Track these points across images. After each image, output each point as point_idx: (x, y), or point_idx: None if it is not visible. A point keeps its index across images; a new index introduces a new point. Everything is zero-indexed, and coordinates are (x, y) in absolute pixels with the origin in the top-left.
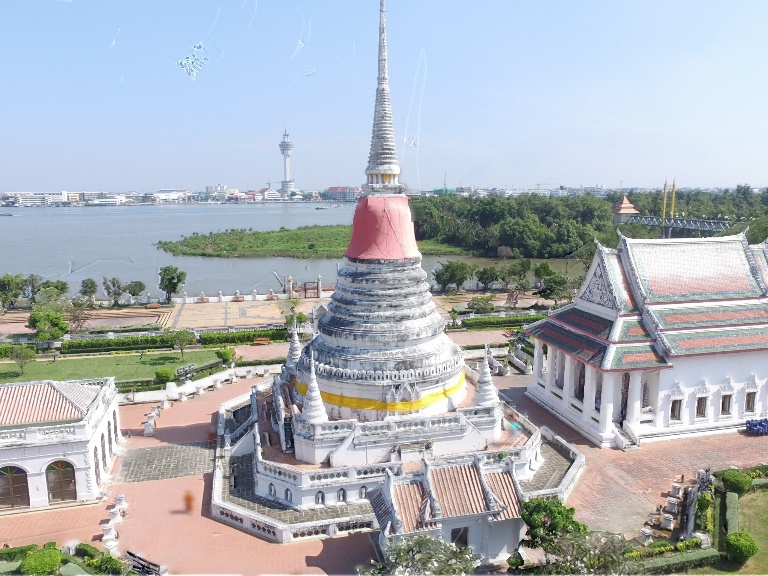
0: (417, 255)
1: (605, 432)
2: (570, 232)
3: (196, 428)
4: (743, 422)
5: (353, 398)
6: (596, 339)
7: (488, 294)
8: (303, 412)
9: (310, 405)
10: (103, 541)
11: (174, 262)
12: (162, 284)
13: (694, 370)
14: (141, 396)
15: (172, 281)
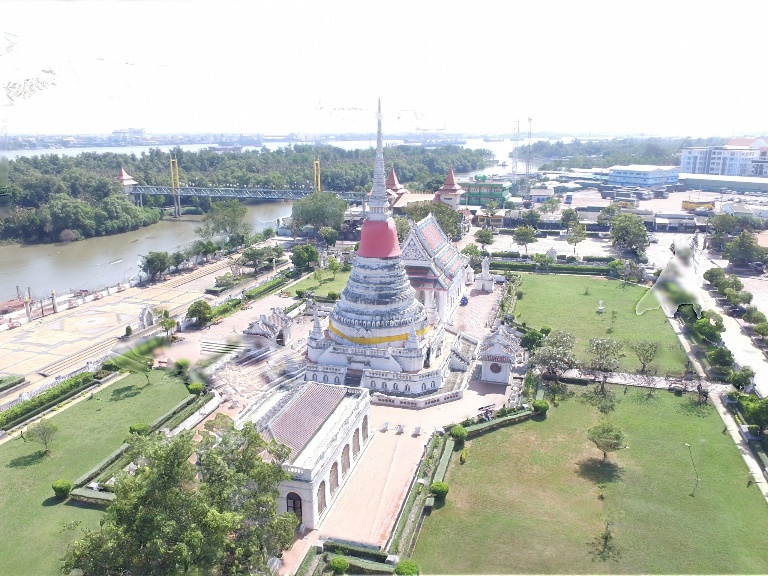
0: None
1: (444, 320)
2: (117, 208)
3: None
4: (460, 301)
5: None
6: (427, 277)
7: (185, 274)
8: (414, 345)
9: None
10: (421, 435)
11: None
12: None
13: None
14: (207, 408)
15: None
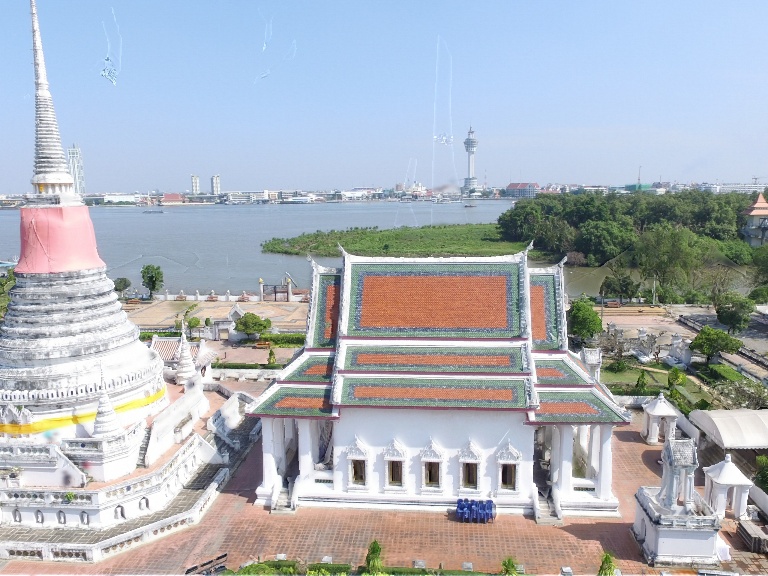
0: (74, 269)
1: (264, 486)
2: None
3: None
4: (455, 500)
5: None
6: None
7: None
8: None
9: None
10: None
11: (248, 259)
12: (144, 281)
13: (382, 425)
14: None
15: (153, 279)
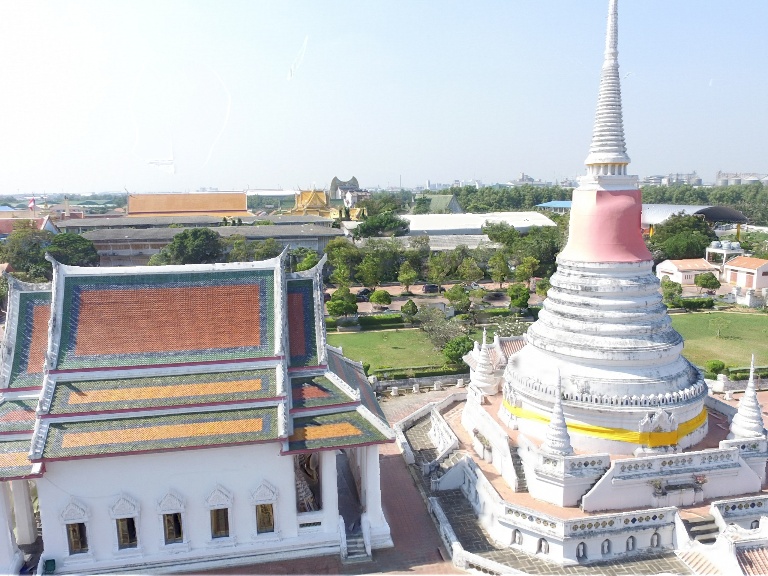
0: None
1: None
2: None
3: None
4: None
5: None
6: None
7: None
8: None
9: None
10: None
11: None
12: None
13: None
14: None
15: None
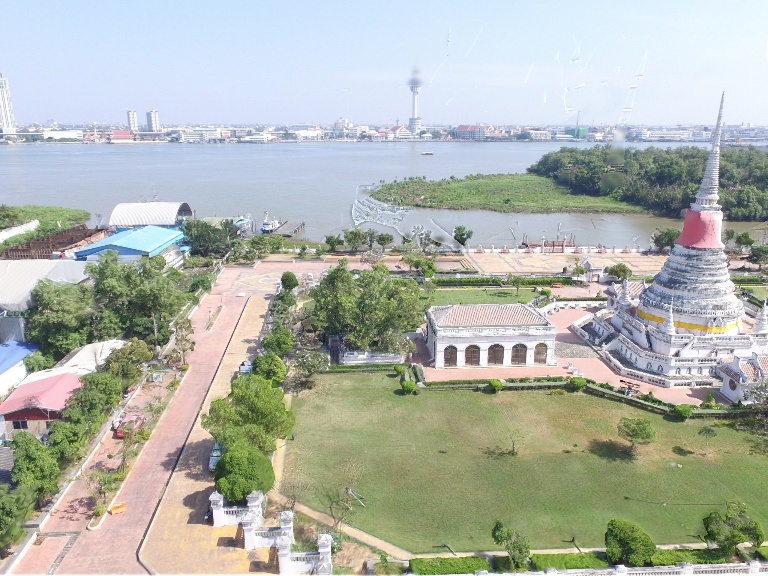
0: None
1: None
2: (750, 198)
3: (566, 335)
4: None
5: (687, 323)
6: None
7: None
8: (664, 328)
9: (669, 325)
10: None
11: None
12: None
13: None
14: None
15: (462, 237)
